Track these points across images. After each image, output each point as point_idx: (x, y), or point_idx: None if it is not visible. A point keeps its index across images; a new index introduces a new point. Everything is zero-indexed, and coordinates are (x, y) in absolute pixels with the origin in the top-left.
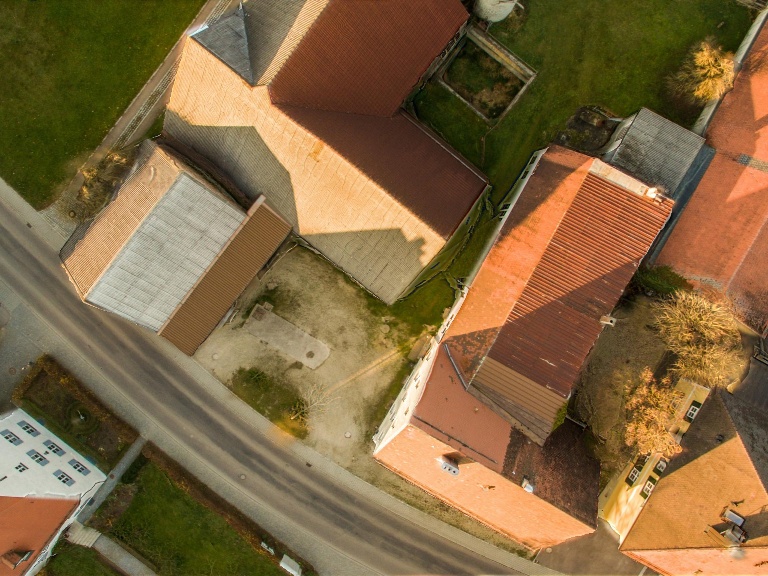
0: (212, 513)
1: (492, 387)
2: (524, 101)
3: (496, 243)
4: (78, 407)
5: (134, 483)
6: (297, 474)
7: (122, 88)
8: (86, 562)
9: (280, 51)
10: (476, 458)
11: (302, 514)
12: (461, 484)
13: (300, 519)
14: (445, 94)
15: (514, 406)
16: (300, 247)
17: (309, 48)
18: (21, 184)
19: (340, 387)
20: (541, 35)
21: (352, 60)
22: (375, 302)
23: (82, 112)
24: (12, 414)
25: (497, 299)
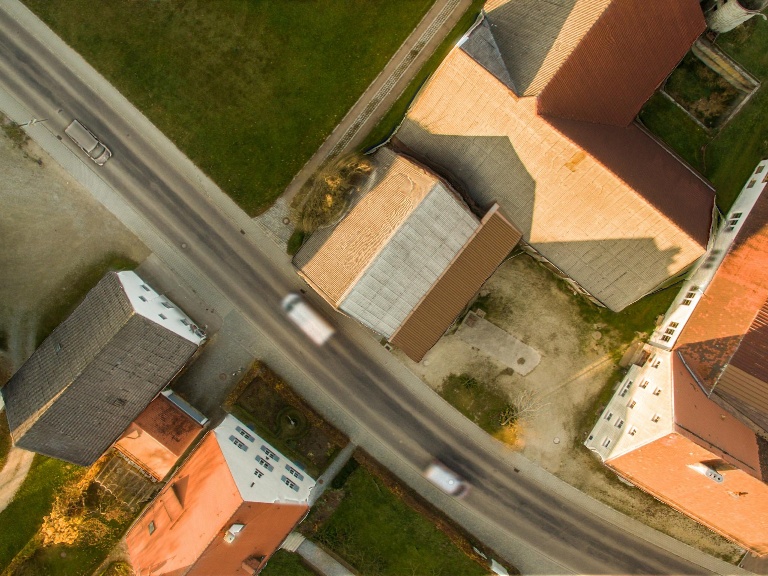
0: (420, 518)
1: (734, 394)
2: (746, 111)
3: (730, 252)
4: (288, 413)
5: (342, 488)
6: (505, 479)
7: (340, 96)
8: (288, 566)
9: (546, 62)
10: (738, 465)
11: (509, 519)
12: (705, 490)
13: (507, 524)
14: (666, 104)
15: (757, 413)
16: (523, 255)
17: (577, 59)
18: (236, 191)
19: (550, 393)
20: (767, 46)
21: (607, 71)
22: (588, 309)
23: (300, 120)
24: (225, 420)
25: (736, 307)
